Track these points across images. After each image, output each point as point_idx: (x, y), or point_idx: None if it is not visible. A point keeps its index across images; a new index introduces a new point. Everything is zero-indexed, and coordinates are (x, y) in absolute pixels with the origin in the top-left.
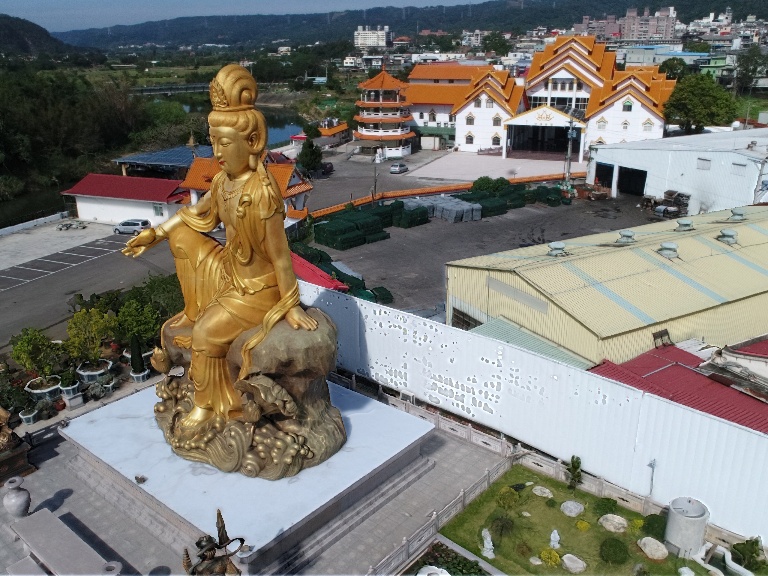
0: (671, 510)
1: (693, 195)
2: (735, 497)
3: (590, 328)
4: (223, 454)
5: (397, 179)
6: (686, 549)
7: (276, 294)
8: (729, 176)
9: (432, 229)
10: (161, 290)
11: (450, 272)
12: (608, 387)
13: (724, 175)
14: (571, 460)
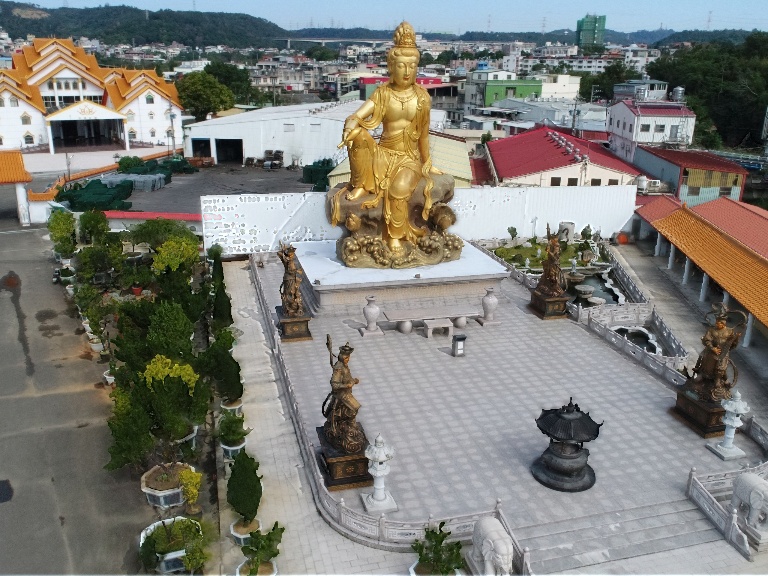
0: (565, 225)
1: (285, 151)
2: (568, 219)
3: (464, 178)
4: (426, 258)
5: (76, 162)
6: (572, 240)
7: (420, 159)
8: (310, 133)
9: (146, 197)
10: (163, 230)
11: (333, 181)
12: (511, 191)
13: (306, 133)
14: (508, 230)
